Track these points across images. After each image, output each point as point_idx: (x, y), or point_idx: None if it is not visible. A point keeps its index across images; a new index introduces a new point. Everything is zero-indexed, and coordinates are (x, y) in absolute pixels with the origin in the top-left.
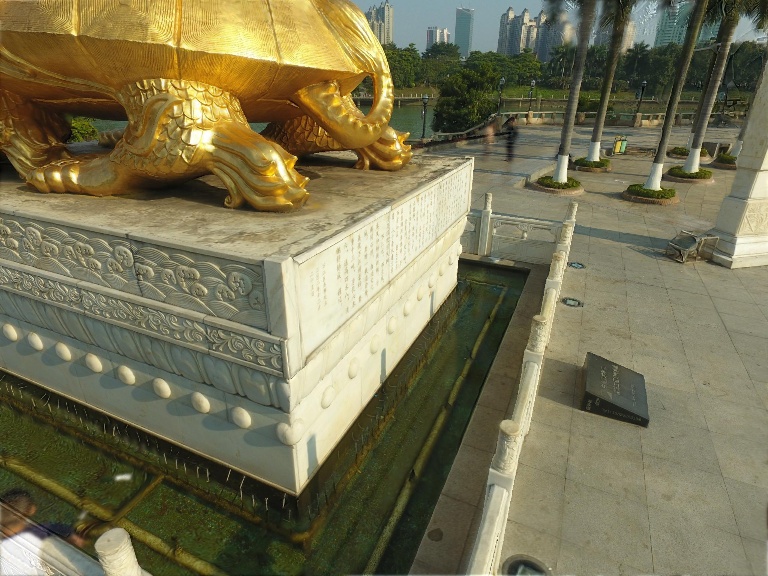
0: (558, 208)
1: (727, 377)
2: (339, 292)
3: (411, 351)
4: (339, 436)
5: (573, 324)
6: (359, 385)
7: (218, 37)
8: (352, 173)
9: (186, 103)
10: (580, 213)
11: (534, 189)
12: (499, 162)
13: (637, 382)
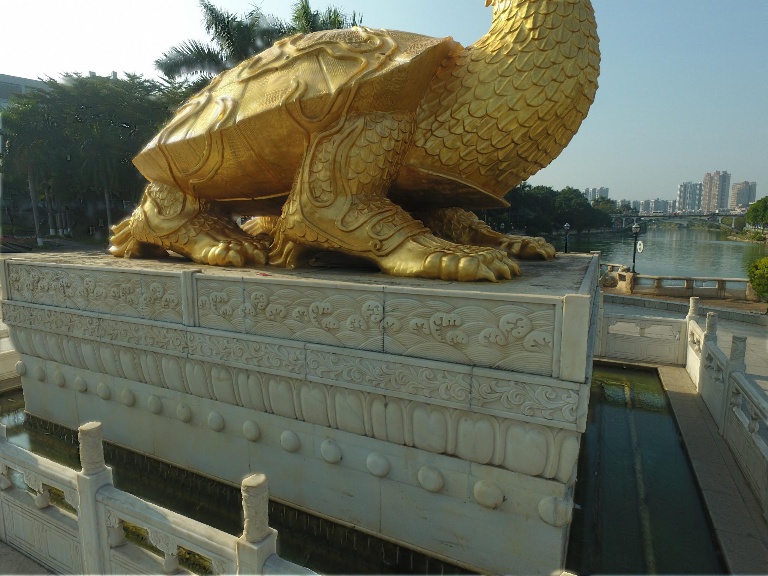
0: None
1: (5, 350)
2: None
3: None
4: None
5: None
6: None
7: None
8: None
9: None
10: None
11: None
12: None
13: None
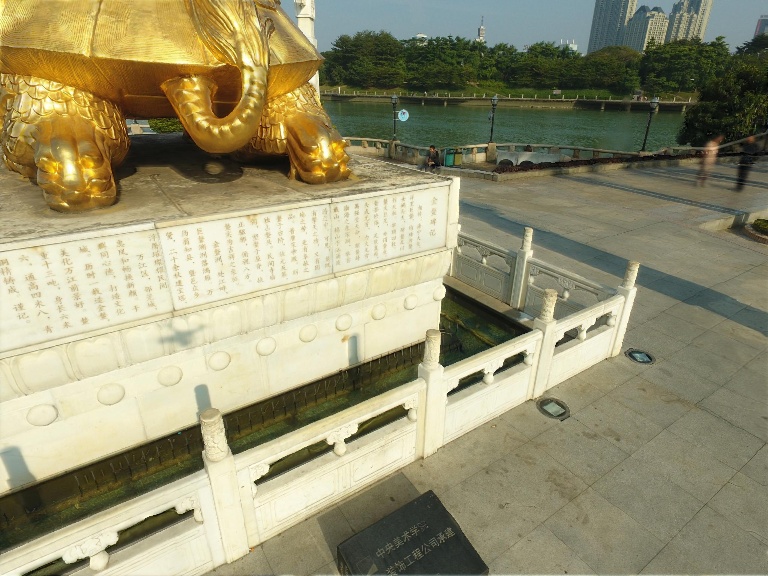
0: (730, 267)
1: None
2: (19, 308)
3: (282, 398)
4: (88, 460)
5: (509, 440)
6: (135, 415)
7: (25, 31)
8: (267, 181)
9: (17, 97)
10: (761, 281)
11: (742, 234)
12: (718, 190)
13: (457, 574)
